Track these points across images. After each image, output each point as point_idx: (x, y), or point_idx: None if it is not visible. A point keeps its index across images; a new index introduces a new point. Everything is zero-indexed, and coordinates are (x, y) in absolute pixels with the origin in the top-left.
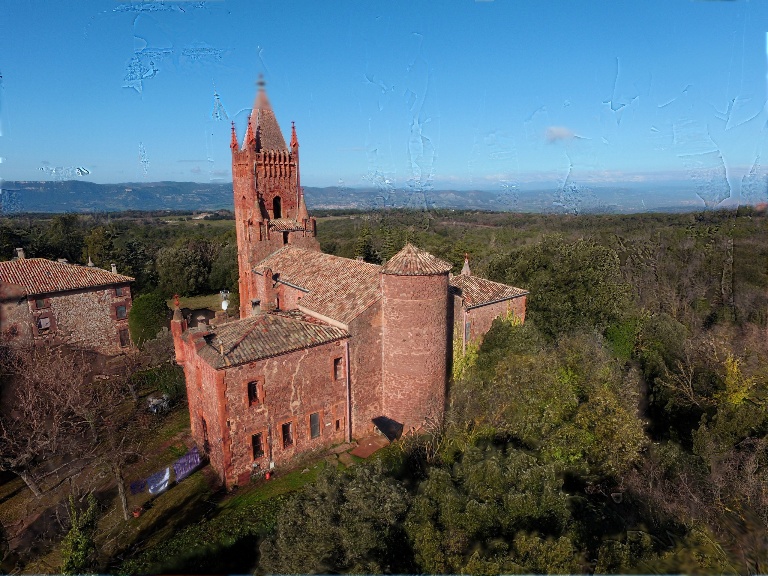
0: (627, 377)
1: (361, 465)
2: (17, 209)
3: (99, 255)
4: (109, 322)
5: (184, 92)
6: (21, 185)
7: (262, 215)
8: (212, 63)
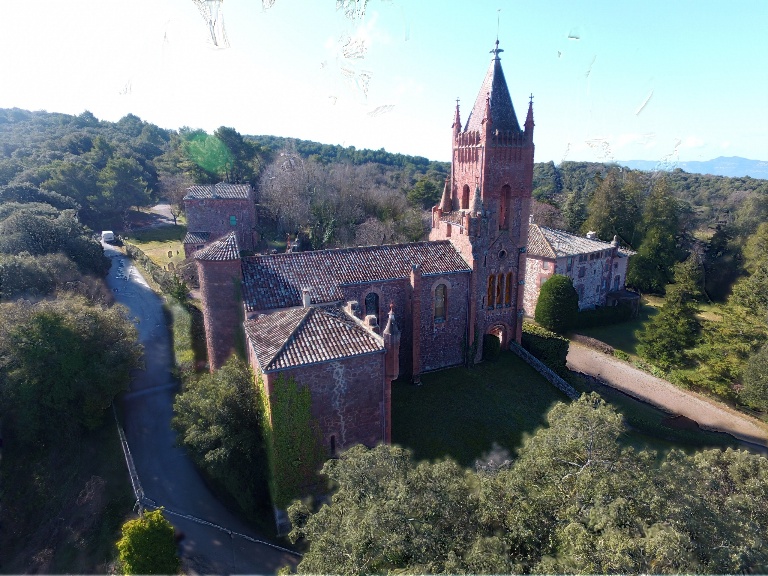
0: (6, 337)
1: (187, 349)
2: (633, 185)
3: (762, 246)
4: (535, 288)
5: (365, 102)
6: (620, 164)
7: (445, 203)
8: (345, 80)
